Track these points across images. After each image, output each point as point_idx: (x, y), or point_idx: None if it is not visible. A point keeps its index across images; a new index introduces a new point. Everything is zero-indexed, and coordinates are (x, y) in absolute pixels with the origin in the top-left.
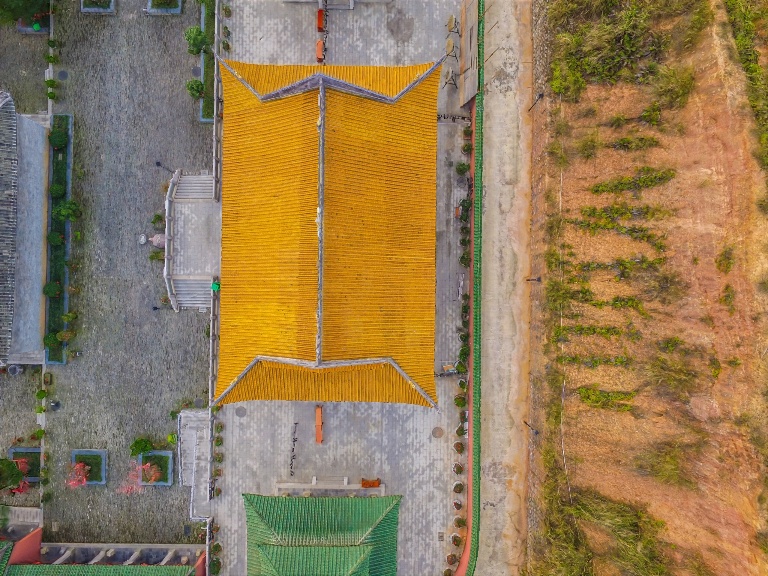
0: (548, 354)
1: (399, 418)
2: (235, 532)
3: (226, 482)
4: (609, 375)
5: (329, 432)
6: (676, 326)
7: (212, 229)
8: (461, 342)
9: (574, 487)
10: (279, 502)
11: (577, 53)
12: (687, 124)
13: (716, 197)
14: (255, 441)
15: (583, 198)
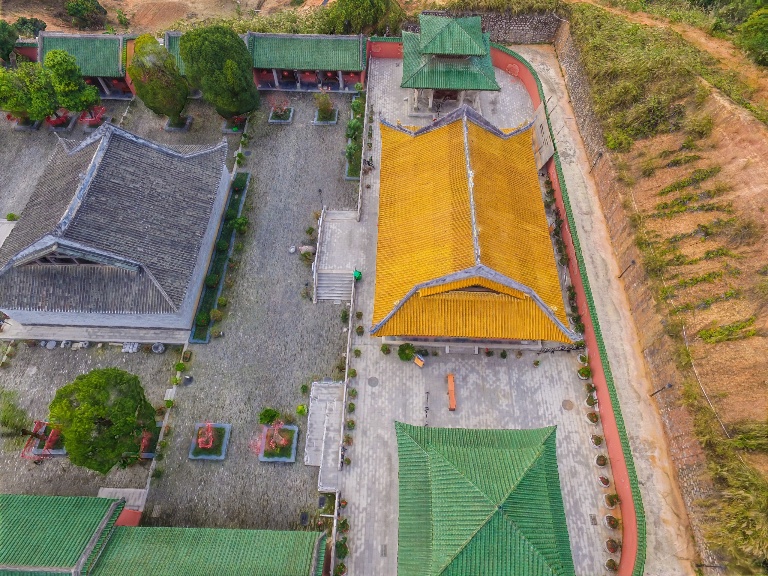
0: (660, 311)
1: (527, 390)
2: (363, 510)
3: (356, 452)
4: (724, 309)
5: (460, 402)
6: (767, 255)
7: (353, 239)
8: (573, 324)
9: (727, 422)
10: (432, 431)
11: (621, 126)
12: (717, 143)
13: (759, 169)
14: (387, 410)
15: (654, 200)
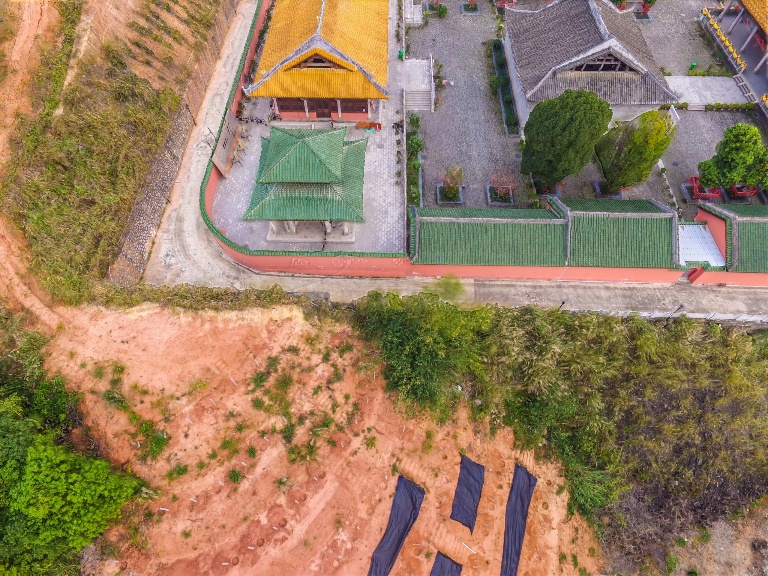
0: None
1: None
2: None
3: None
4: None
5: None
6: None
7: (407, 79)
8: None
9: None
10: None
11: None
12: (112, 38)
13: None
14: None
15: (179, 48)
